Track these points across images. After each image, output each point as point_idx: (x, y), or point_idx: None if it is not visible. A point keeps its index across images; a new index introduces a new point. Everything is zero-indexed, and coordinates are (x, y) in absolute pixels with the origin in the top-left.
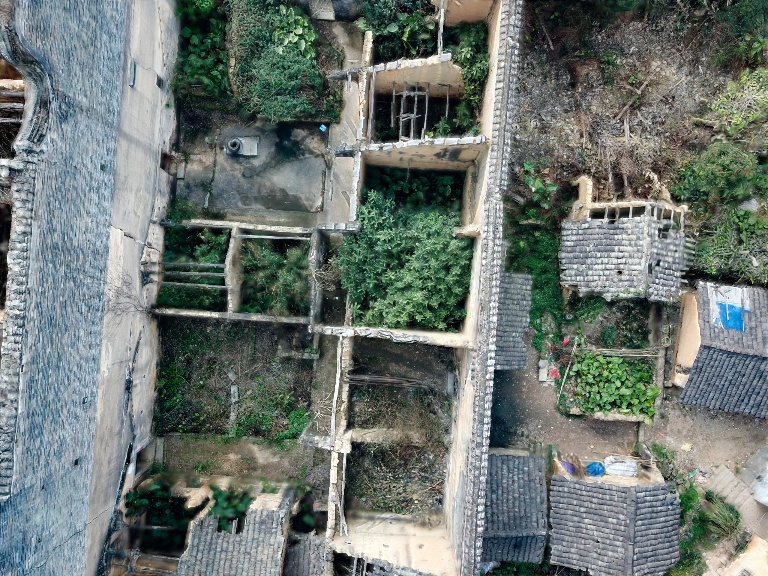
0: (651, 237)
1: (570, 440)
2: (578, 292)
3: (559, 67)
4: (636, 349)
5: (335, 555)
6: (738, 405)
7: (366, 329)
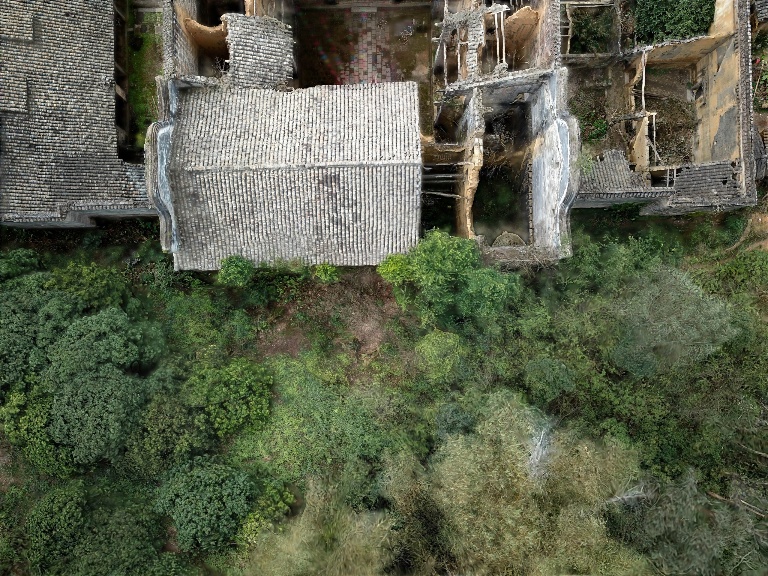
0: None
1: (762, 126)
2: None
3: None
4: None
5: (653, 173)
6: None
7: None
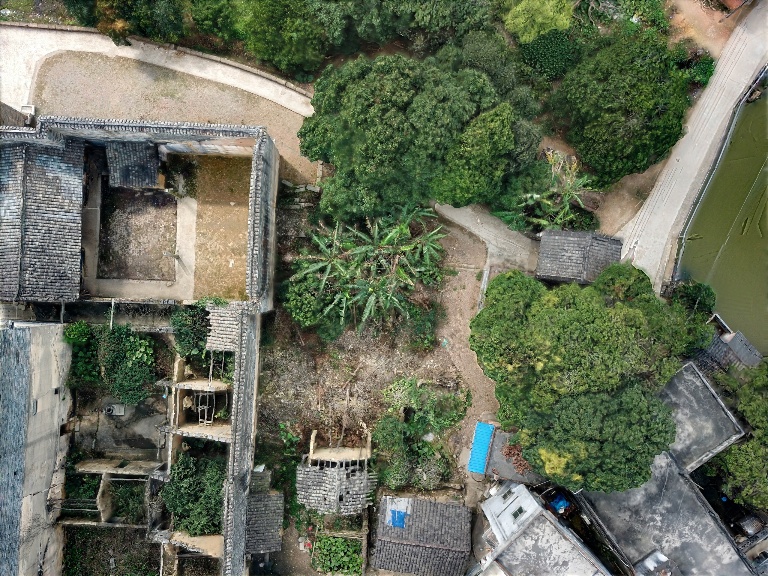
0: (340, 480)
1: None
2: (306, 508)
3: (308, 356)
4: (354, 531)
5: None
6: (407, 569)
7: (175, 540)
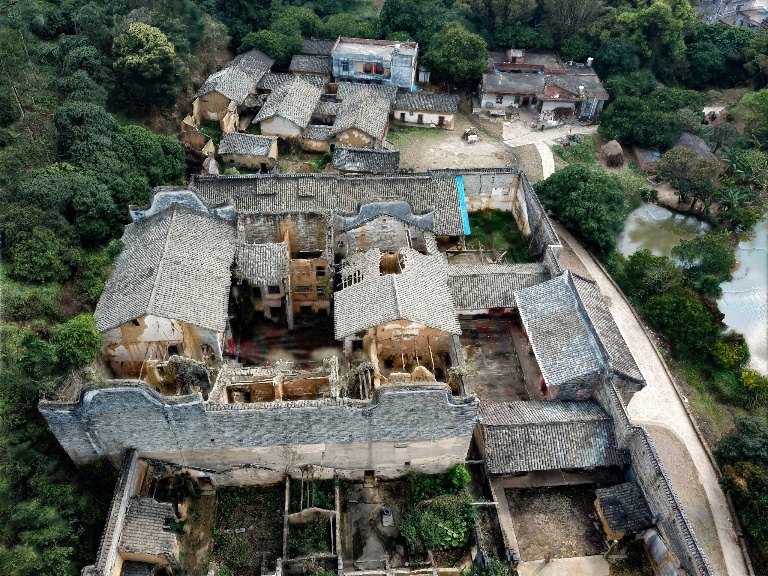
0: None
1: None
2: None
3: None
4: None
5: None
6: None
7: None
